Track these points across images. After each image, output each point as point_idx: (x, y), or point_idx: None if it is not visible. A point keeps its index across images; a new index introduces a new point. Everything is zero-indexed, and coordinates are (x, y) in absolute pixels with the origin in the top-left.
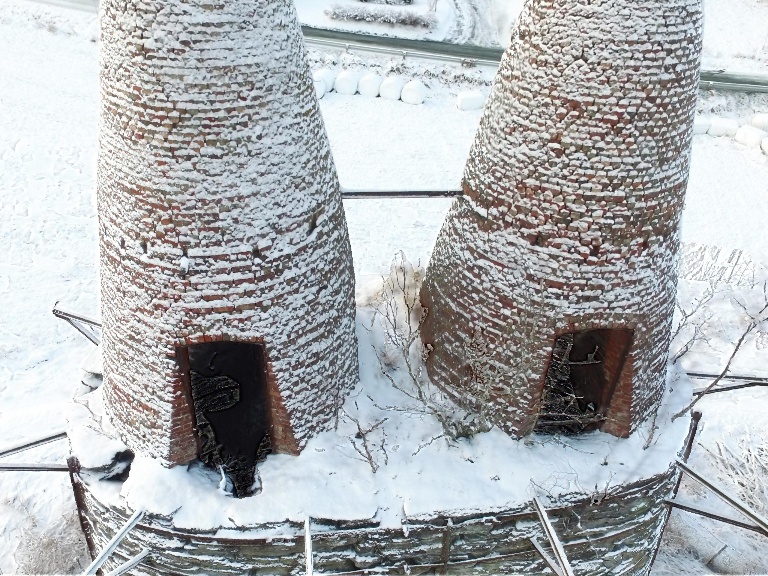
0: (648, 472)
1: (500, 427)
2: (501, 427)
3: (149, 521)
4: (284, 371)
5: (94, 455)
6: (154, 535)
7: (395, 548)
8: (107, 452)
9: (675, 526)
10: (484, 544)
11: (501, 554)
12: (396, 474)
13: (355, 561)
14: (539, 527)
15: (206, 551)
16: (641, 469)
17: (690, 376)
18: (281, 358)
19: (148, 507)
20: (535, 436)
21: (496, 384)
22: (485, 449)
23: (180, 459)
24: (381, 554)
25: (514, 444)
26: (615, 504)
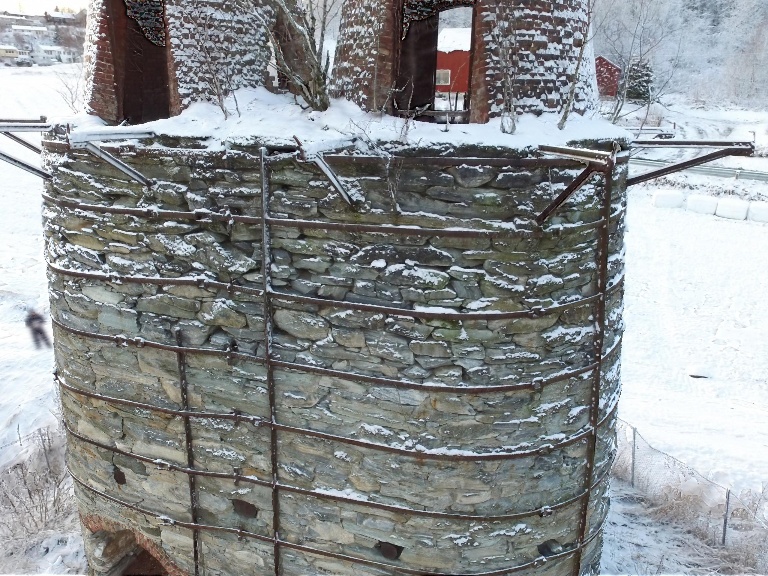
0: (492, 141)
1: (355, 101)
2: (355, 101)
3: (55, 138)
4: (176, 18)
5: (56, 114)
6: (56, 154)
7: (220, 186)
8: (66, 115)
9: (761, 562)
10: (304, 202)
11: (322, 221)
12: (241, 120)
13: (186, 198)
14: (359, 185)
15: (82, 168)
16: (484, 137)
17: (638, 145)
18: (175, 4)
19: (55, 120)
20: (389, 115)
21: (354, 51)
22: (330, 112)
23: (101, 111)
24: (209, 193)
25: (360, 111)
26: (449, 175)
